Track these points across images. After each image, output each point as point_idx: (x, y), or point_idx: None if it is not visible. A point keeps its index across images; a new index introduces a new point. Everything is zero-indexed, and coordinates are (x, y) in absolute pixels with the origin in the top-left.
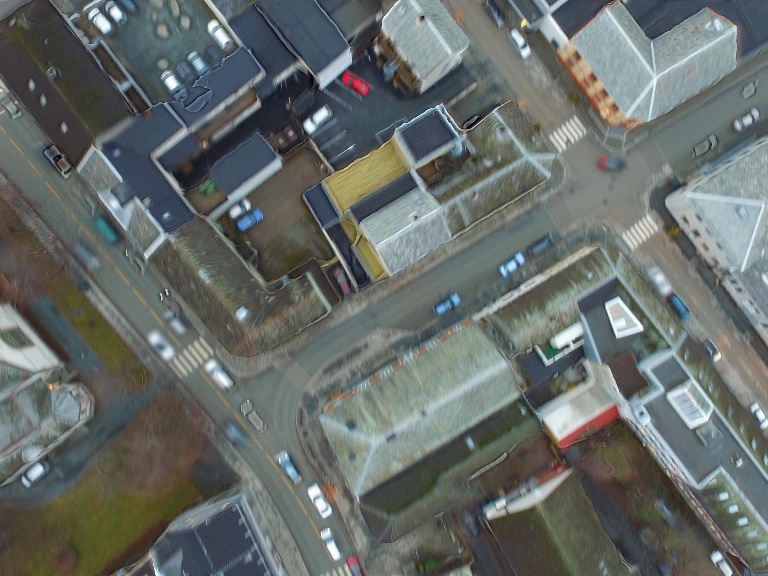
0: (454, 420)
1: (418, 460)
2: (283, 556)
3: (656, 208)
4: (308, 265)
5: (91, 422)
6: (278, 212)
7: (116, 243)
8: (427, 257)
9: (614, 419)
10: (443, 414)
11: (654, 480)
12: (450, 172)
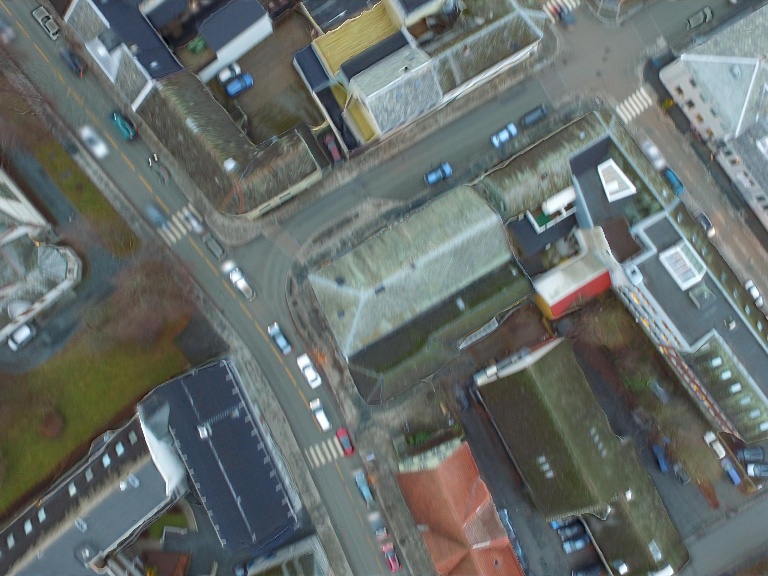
0: (444, 278)
1: (408, 321)
2: (272, 426)
3: (650, 81)
4: (298, 127)
5: (78, 286)
6: (268, 78)
7: (104, 106)
8: (418, 126)
9: (606, 289)
10: (433, 270)
11: (647, 357)
12: (441, 32)
